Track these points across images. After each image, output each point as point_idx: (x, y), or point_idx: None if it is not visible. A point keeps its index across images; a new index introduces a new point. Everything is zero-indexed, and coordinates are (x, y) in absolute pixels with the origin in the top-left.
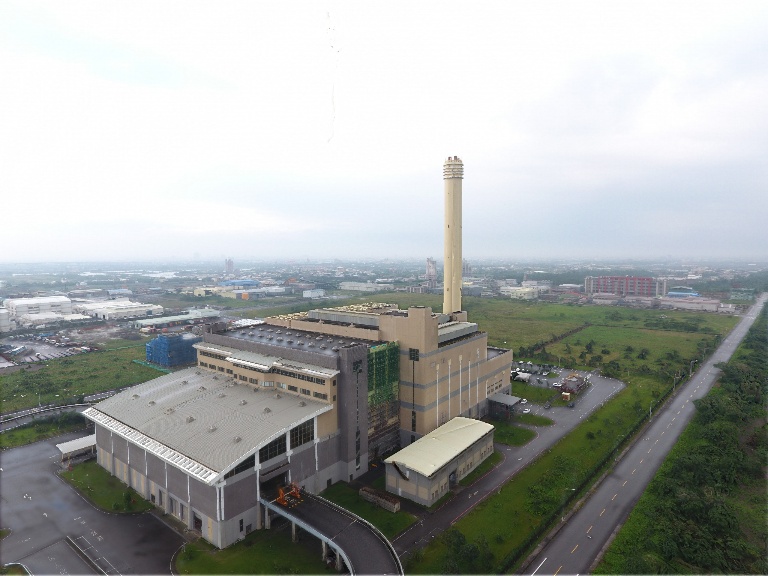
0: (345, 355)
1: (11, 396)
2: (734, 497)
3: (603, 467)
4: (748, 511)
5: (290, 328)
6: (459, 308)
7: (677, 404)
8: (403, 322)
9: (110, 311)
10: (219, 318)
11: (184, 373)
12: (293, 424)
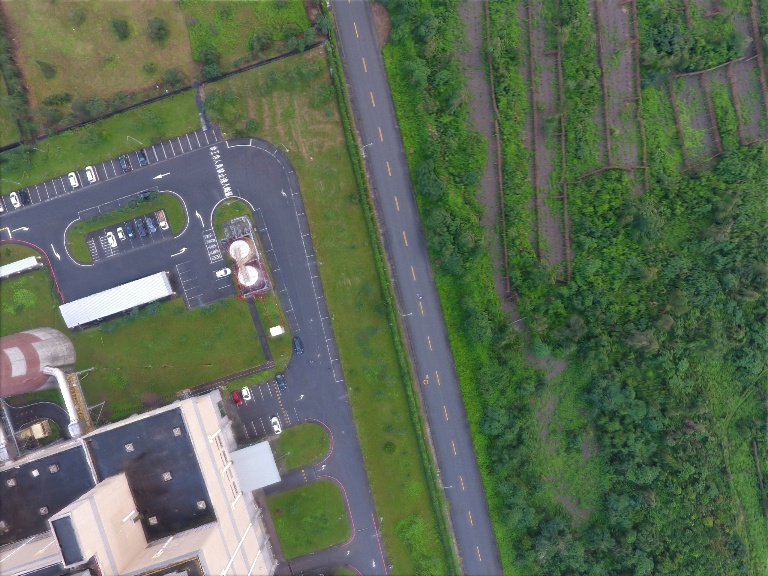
0: None
1: None
2: (541, 447)
3: (441, 508)
4: (558, 466)
5: None
6: None
7: (387, 199)
8: None
9: None
10: None
11: None
12: None
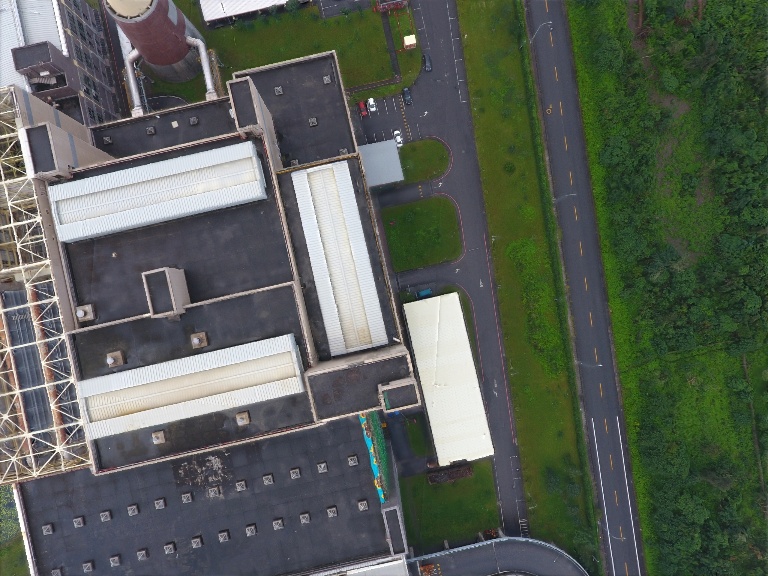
0: None
1: None
2: (656, 187)
3: (554, 234)
4: (671, 208)
5: None
6: None
7: None
8: None
9: None
10: None
11: None
12: None
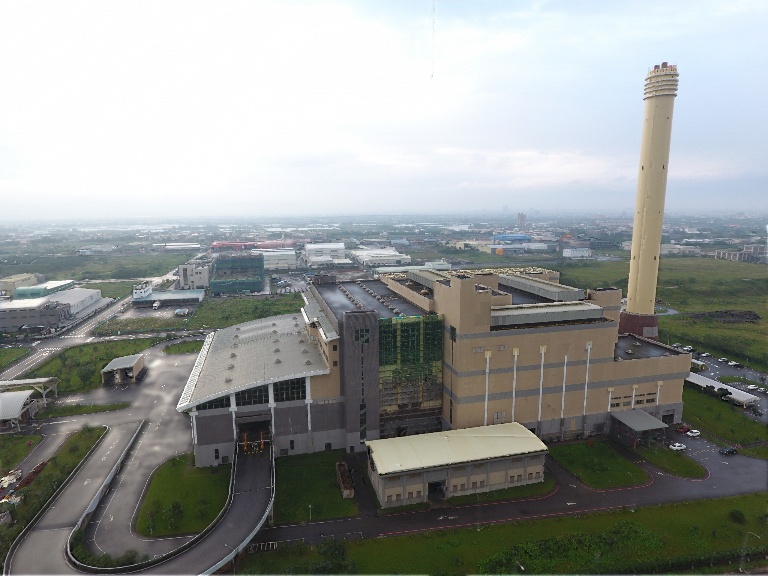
0: (344, 321)
1: (239, 316)
2: None
3: (694, 569)
4: None
5: (387, 287)
6: (650, 284)
7: None
8: (447, 293)
9: (367, 258)
10: None
11: (288, 316)
12: (273, 379)
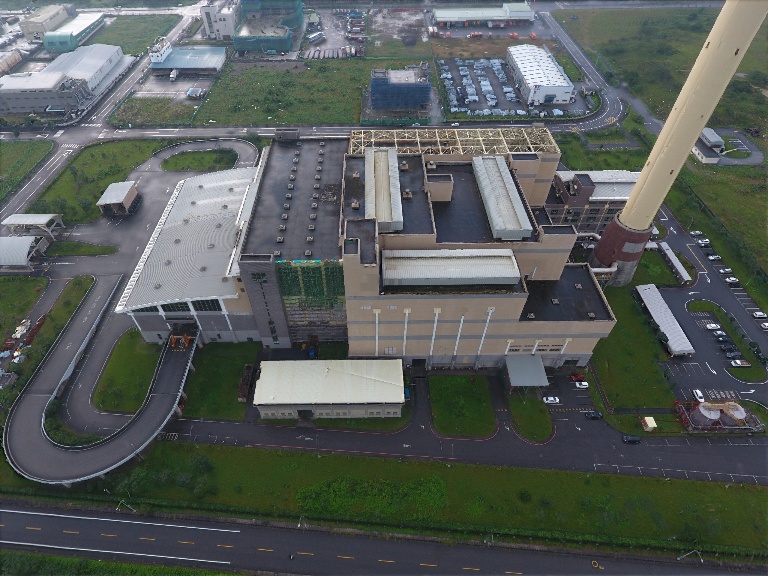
0: None
1: (249, 106)
2: None
3: (449, 532)
4: None
5: None
6: (653, 199)
7: None
8: None
9: None
10: (532, 22)
11: (251, 173)
12: (188, 299)
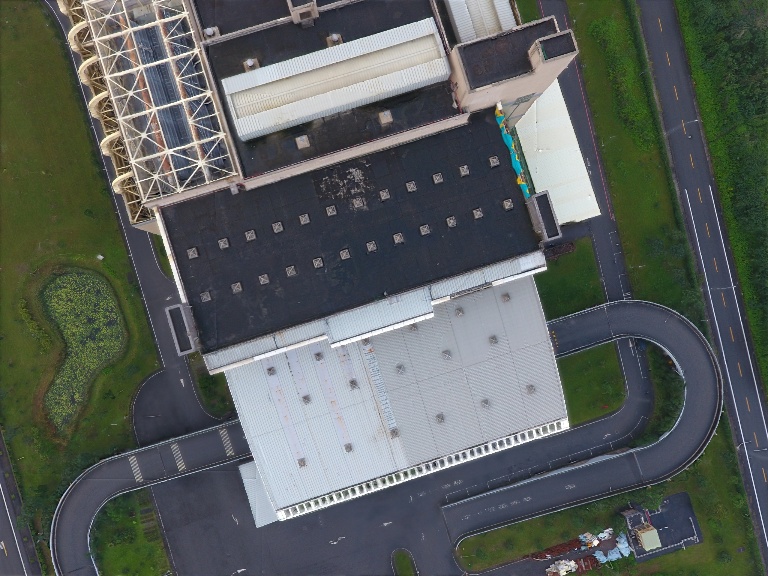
0: None
1: None
2: None
3: None
4: None
5: (249, 190)
6: None
7: None
8: (522, 81)
9: None
10: None
11: (250, 389)
12: None
